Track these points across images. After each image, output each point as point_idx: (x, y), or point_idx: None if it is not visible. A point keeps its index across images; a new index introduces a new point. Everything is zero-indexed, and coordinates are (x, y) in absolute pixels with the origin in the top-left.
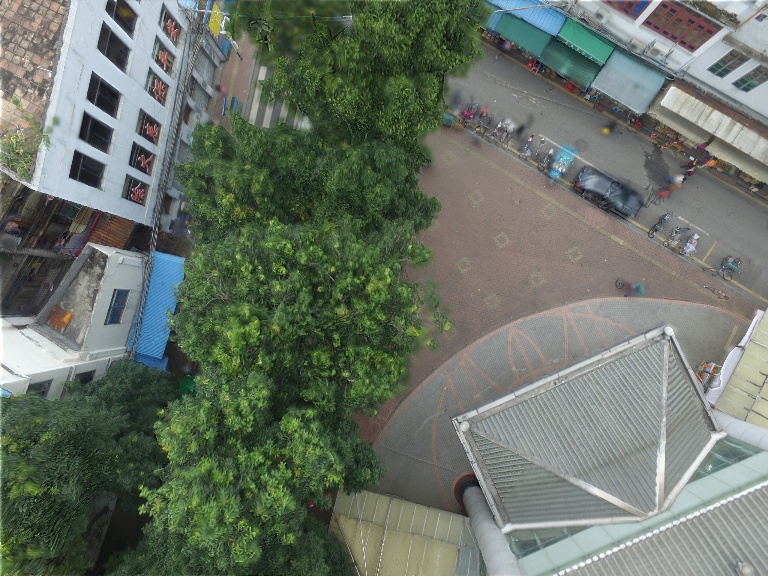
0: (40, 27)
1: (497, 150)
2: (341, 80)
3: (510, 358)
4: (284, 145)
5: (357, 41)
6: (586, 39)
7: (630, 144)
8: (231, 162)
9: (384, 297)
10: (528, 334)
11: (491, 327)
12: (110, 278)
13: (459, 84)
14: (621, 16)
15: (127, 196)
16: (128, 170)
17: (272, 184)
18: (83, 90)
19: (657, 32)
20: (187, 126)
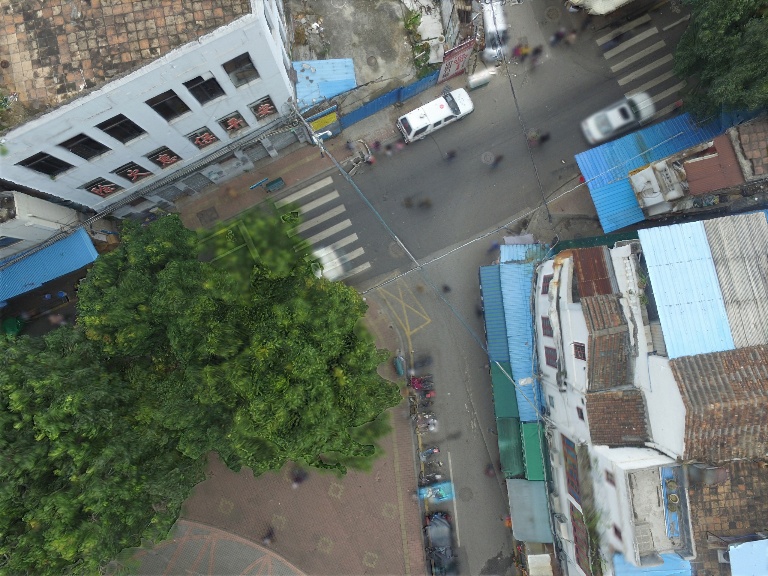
0: (117, 45)
1: (409, 427)
2: (216, 380)
3: (241, 574)
4: (181, 326)
5: (248, 377)
6: (536, 450)
7: (498, 534)
8: (158, 271)
9: (63, 557)
10: (273, 573)
11: (256, 538)
12: (3, 229)
13: (440, 353)
14: (565, 477)
15: (88, 187)
16: (105, 175)
17: (142, 340)
18: (95, 121)
19: (571, 520)
20: (218, 166)
